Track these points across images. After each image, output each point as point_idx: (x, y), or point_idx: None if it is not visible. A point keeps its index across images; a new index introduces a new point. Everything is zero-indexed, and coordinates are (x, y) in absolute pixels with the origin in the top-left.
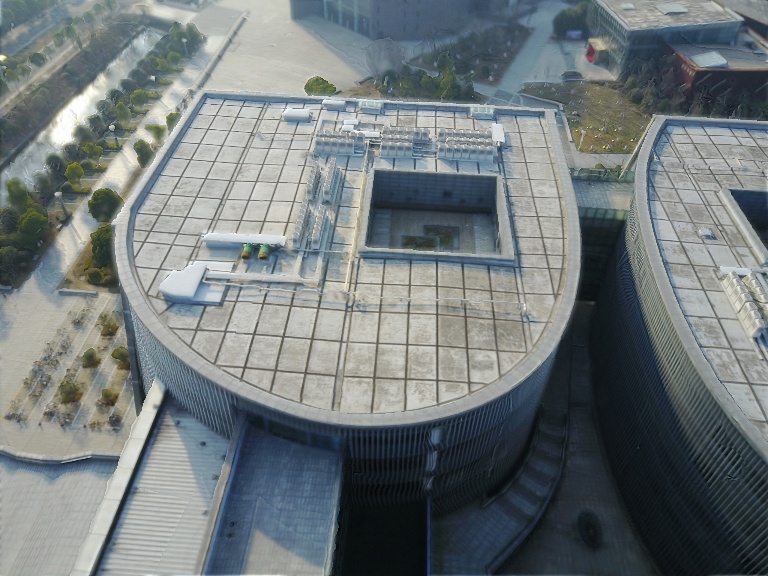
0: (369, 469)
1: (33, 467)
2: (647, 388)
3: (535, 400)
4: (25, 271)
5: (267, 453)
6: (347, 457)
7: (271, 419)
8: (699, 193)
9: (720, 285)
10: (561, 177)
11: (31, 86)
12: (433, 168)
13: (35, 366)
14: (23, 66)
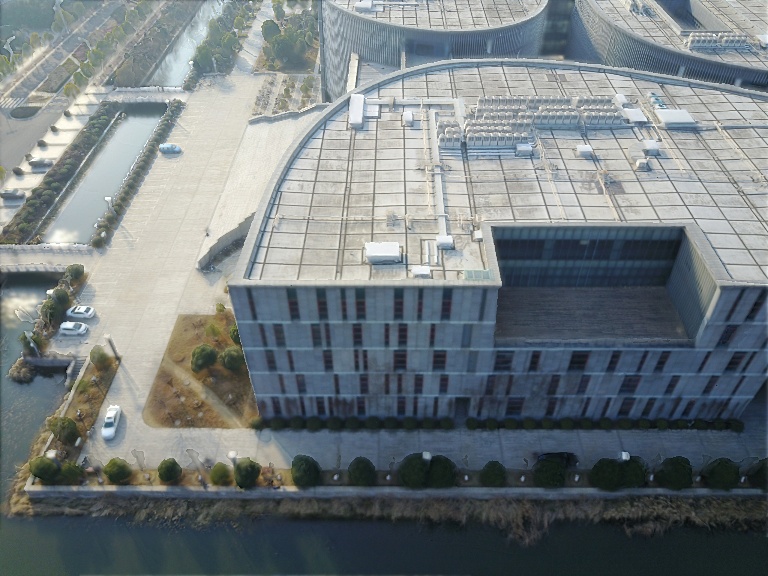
0: None
1: (283, 119)
2: (586, 52)
3: None
4: (229, 68)
5: (417, 58)
6: None
7: (418, 43)
8: None
9: None
10: None
11: None
12: None
13: None
14: None
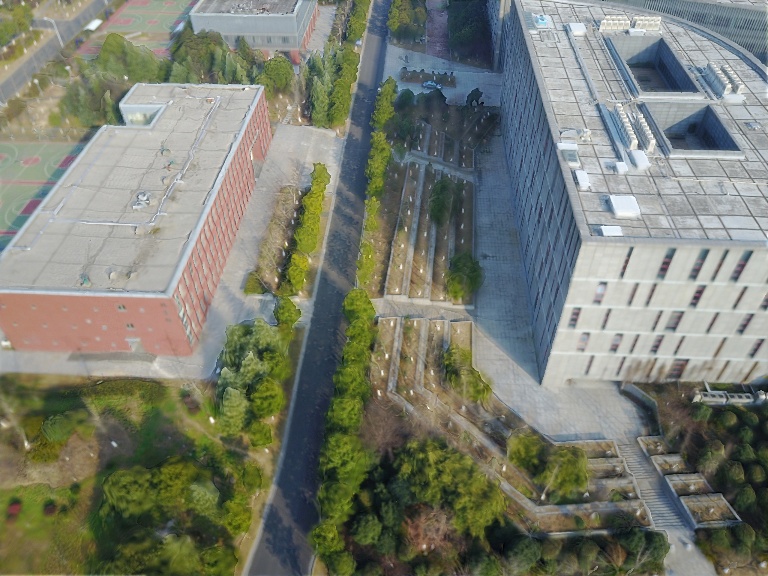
0: None
1: None
2: None
3: None
4: None
5: None
6: None
7: None
8: (763, 159)
9: None
10: None
11: None
12: None
13: None
14: None
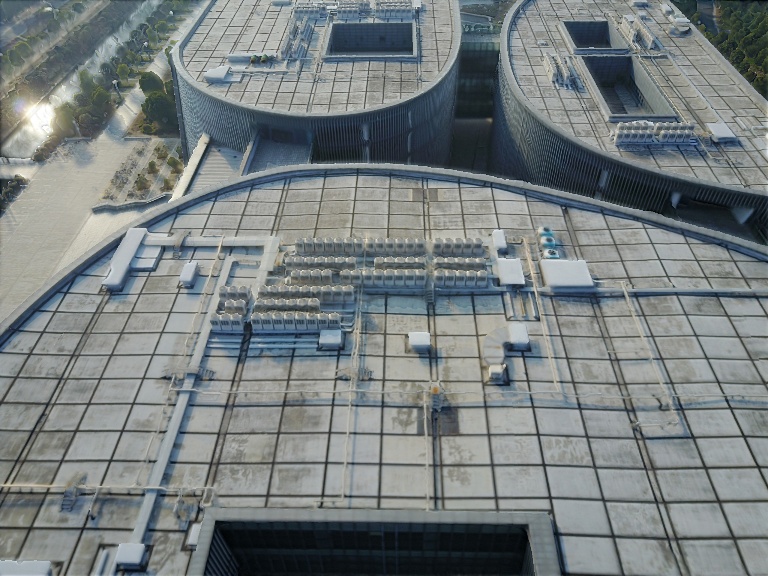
0: (330, 156)
1: (128, 210)
2: (502, 130)
3: (432, 136)
4: (98, 130)
5: (272, 148)
6: (316, 145)
7: (273, 128)
8: (545, 26)
9: (542, 63)
10: (454, 21)
11: (76, 28)
12: (372, 22)
13: (117, 174)
14: (69, 12)
